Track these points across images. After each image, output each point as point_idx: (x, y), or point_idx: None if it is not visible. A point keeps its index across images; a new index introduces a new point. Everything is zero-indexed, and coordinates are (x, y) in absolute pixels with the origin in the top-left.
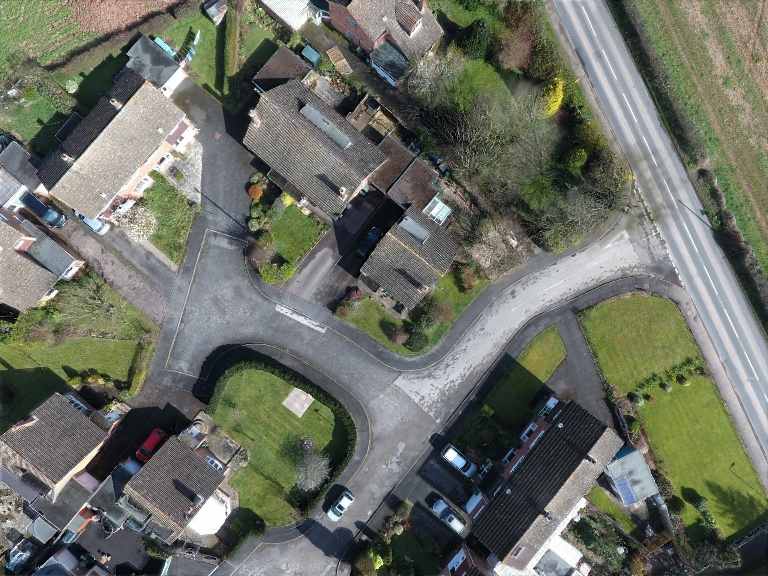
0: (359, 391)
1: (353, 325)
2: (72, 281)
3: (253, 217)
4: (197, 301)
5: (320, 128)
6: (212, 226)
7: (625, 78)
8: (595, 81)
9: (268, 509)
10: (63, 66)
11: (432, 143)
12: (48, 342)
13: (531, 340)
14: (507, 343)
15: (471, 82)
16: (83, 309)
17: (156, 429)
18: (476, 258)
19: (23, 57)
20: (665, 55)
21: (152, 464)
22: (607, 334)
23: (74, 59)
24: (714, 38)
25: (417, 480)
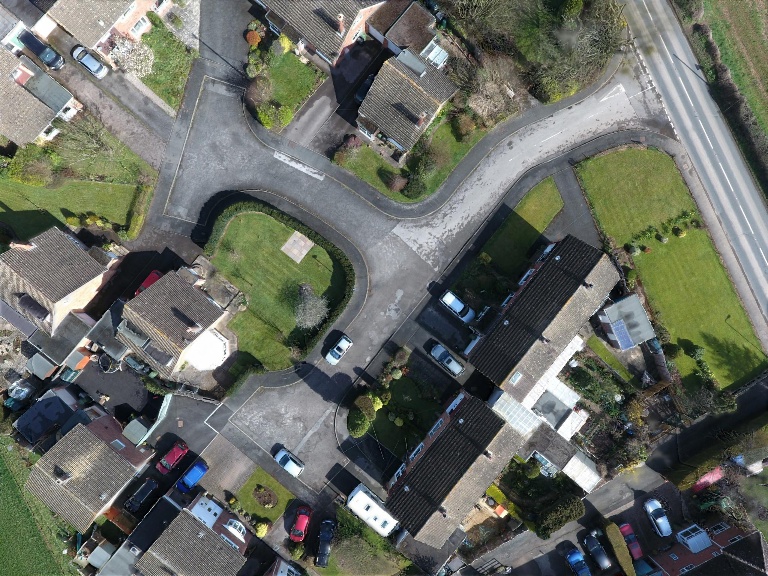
0: (357, 238)
1: (351, 172)
2: (70, 123)
3: (251, 63)
4: (195, 147)
5: None
6: (210, 73)
7: None
8: None
9: (267, 353)
10: None
11: None
12: (46, 180)
13: (528, 190)
14: (504, 193)
15: None
16: (81, 153)
17: (154, 270)
18: (473, 108)
19: None
20: None
21: (151, 291)
22: (603, 186)
23: None
24: None
25: (415, 327)
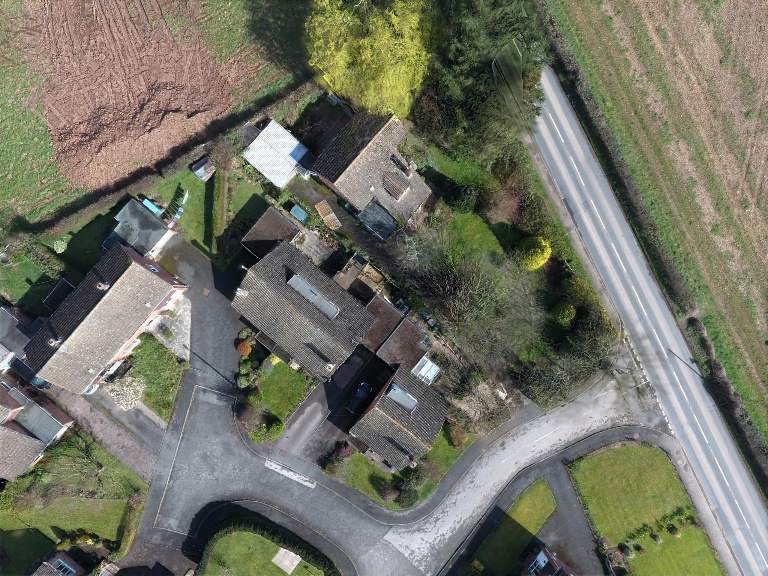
0: (349, 546)
1: (342, 480)
2: (60, 442)
3: (242, 374)
4: (186, 458)
5: (308, 299)
6: (201, 382)
7: (614, 227)
8: (584, 231)
9: None
10: (51, 228)
11: (421, 303)
12: (36, 508)
13: (521, 492)
14: (497, 495)
15: (460, 233)
16: (72, 468)
17: None
18: (466, 410)
19: (12, 215)
20: (653, 204)
21: None
22: (597, 485)
23: (62, 222)
24: (702, 185)
25: None
